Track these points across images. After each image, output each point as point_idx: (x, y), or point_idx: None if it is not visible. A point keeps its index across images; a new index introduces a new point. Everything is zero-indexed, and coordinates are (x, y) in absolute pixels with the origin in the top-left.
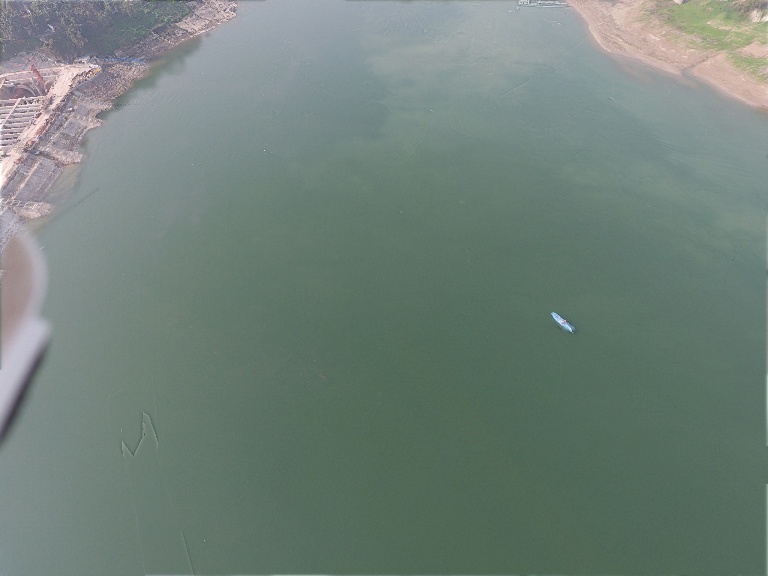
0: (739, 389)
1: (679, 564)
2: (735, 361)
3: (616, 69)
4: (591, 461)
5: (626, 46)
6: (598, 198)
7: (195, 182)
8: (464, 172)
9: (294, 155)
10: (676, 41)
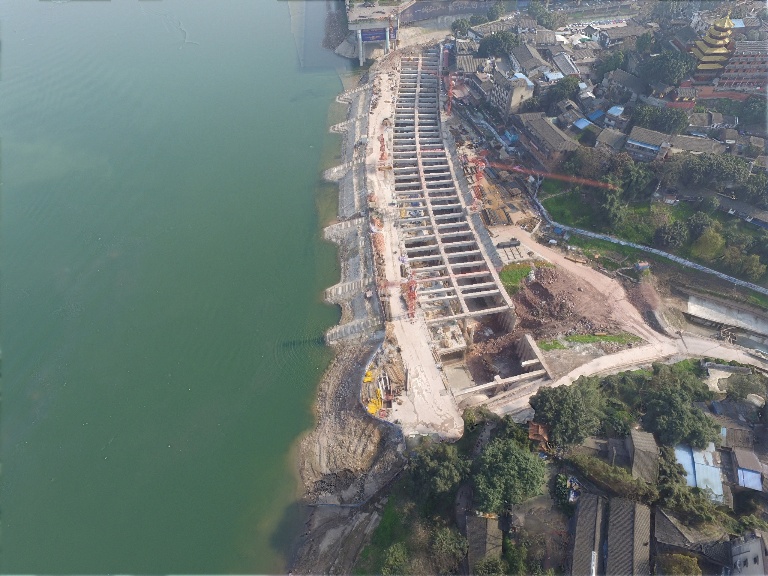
0: None
1: None
2: None
3: None
4: (10, 68)
5: None
6: None
7: (185, 203)
8: None
9: (69, 242)
10: None
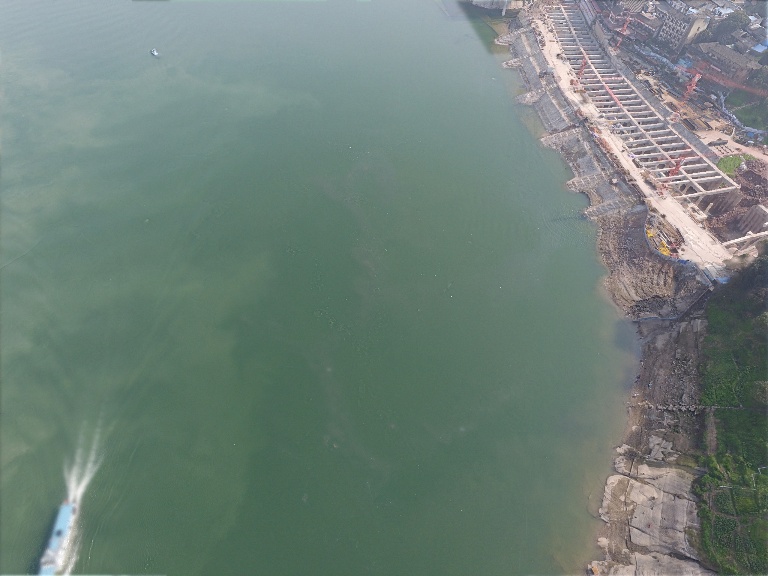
0: (86, 55)
1: (168, 6)
2: (75, 59)
3: None
4: None
5: None
6: (56, 122)
7: (407, 121)
8: (155, 141)
9: (321, 152)
10: None
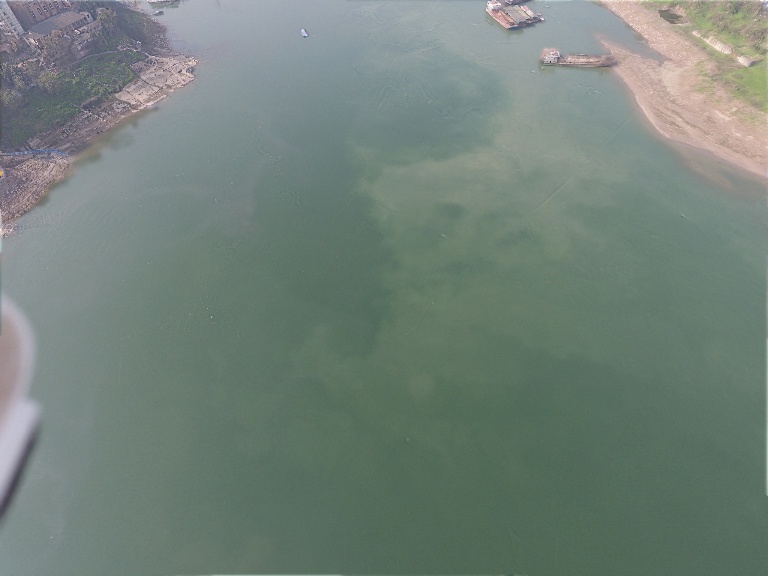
0: None
1: None
2: None
3: (682, 166)
4: None
5: (688, 129)
6: (696, 410)
7: (107, 379)
8: (496, 355)
9: (254, 322)
10: (753, 123)
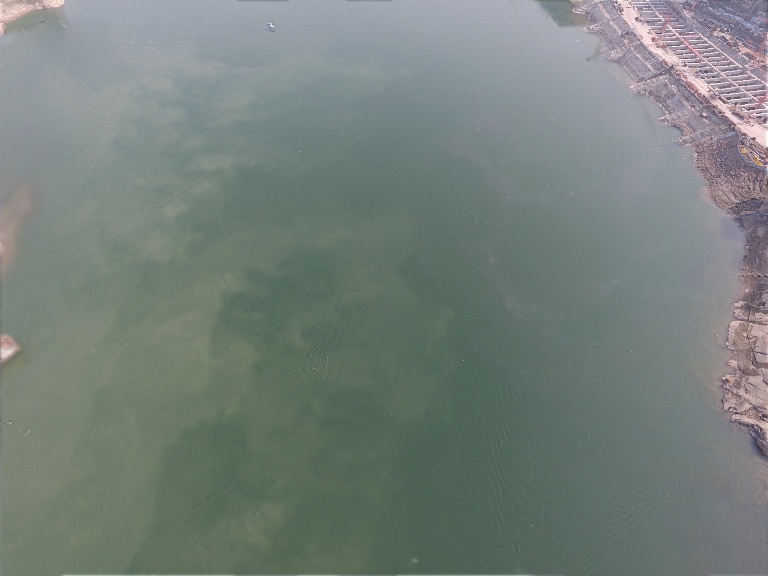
0: (206, 31)
1: None
2: (199, 34)
3: (35, 209)
4: None
5: None
6: (201, 81)
7: (508, 74)
8: (290, 94)
9: None
10: None
